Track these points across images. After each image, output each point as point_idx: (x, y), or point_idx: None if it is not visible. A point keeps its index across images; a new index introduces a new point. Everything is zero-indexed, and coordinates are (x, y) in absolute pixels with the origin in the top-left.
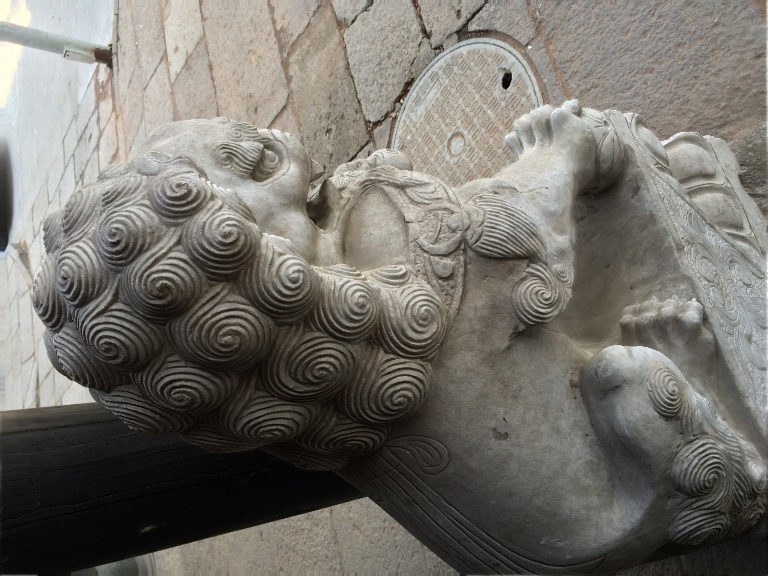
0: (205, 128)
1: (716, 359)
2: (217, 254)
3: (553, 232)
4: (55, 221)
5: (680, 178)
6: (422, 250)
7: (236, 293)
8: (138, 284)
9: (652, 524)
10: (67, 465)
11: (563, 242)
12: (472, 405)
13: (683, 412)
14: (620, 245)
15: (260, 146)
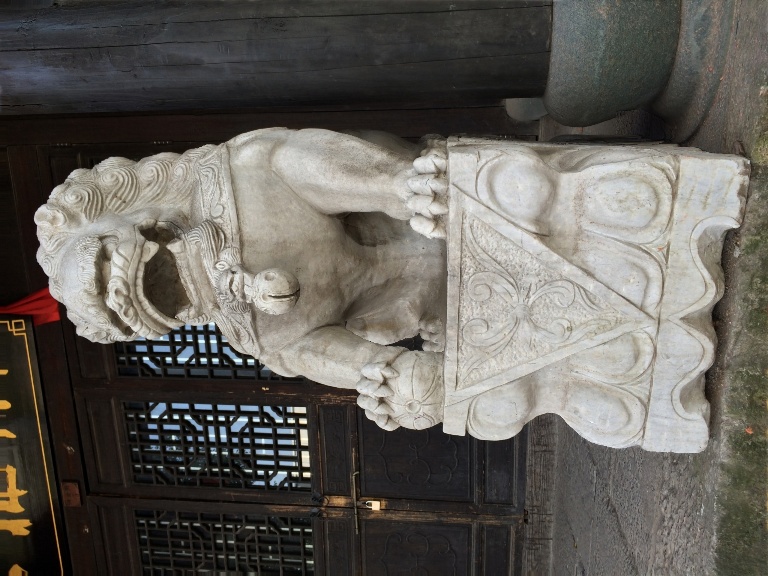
0: None
1: None
2: None
3: None
4: None
5: None
6: None
7: None
8: None
9: None
10: None
11: None
12: None
13: None
14: None
15: None
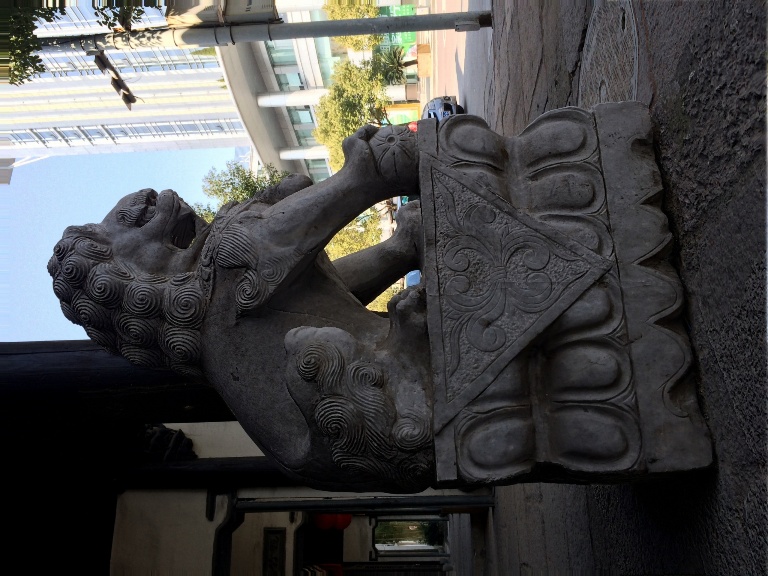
0: (124, 200)
1: (427, 340)
2: None
3: (275, 246)
4: None
5: (529, 161)
6: None
7: (85, 294)
8: None
9: (320, 452)
10: None
11: (283, 252)
12: (220, 358)
13: (318, 377)
14: None
15: (141, 207)
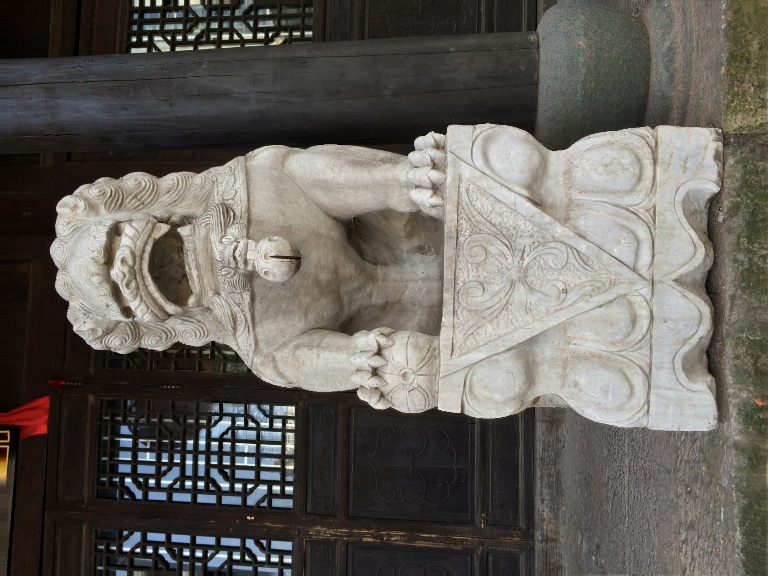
0: (96, 307)
1: None
2: None
3: None
4: None
5: None
6: None
7: None
8: None
9: None
10: (140, 146)
11: None
12: None
13: None
14: None
15: None
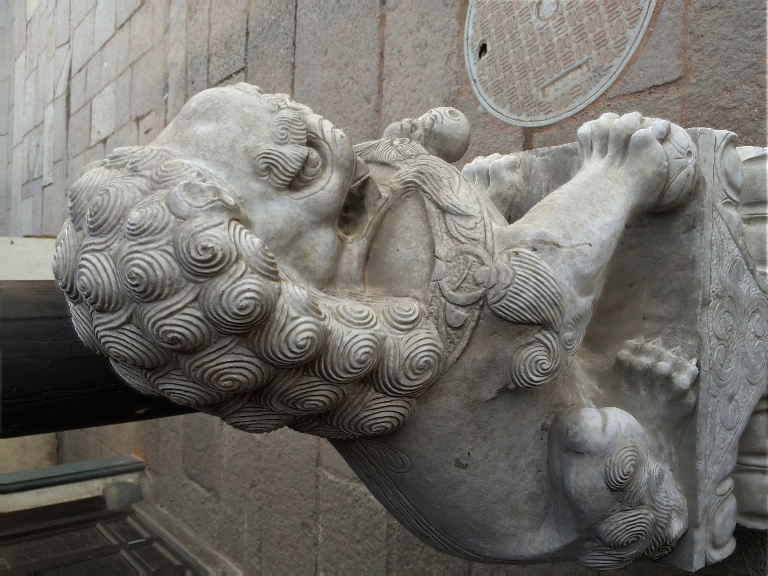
0: (250, 121)
1: (689, 419)
2: (230, 321)
3: (578, 296)
4: (81, 197)
5: (748, 201)
6: (441, 293)
7: (243, 346)
8: (151, 327)
9: (567, 552)
10: (76, 355)
11: (584, 306)
12: (443, 438)
13: (630, 487)
14: (651, 272)
15: (304, 154)
